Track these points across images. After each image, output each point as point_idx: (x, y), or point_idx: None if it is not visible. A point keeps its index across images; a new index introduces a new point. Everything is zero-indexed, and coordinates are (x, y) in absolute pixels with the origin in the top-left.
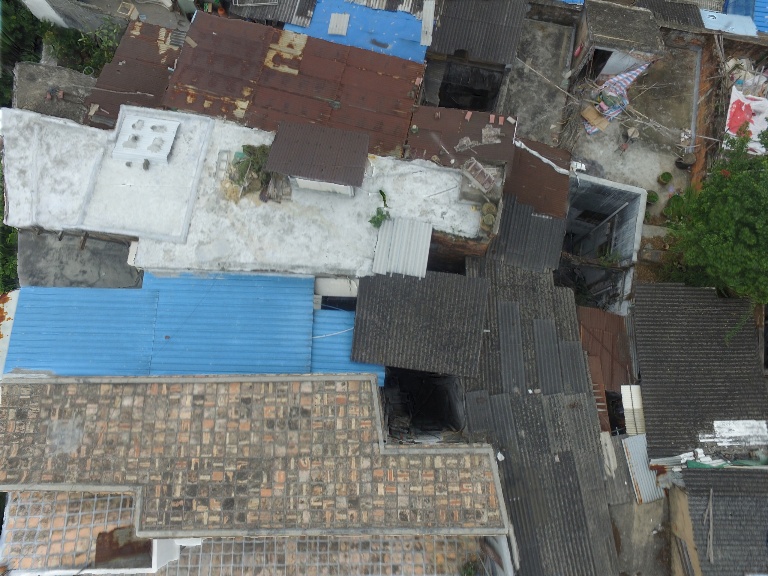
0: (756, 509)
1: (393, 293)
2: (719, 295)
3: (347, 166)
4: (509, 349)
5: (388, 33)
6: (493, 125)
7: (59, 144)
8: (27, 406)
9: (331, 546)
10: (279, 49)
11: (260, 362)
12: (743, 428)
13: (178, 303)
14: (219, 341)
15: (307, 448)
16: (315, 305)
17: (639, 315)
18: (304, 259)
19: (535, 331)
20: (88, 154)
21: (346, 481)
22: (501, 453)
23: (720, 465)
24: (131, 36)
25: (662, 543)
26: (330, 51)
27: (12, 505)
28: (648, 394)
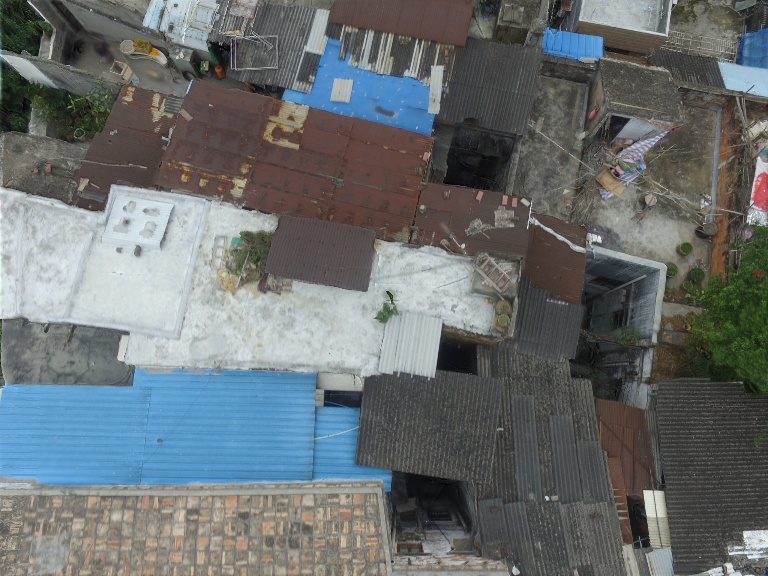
0: None
1: (400, 393)
2: (747, 390)
3: (352, 267)
4: (524, 449)
5: (394, 100)
6: (506, 207)
7: (46, 227)
8: (9, 520)
9: None
10: (279, 122)
11: (259, 467)
12: None
13: (171, 402)
14: (215, 444)
15: (309, 569)
16: (317, 402)
17: (662, 414)
18: (306, 357)
19: (551, 429)
20: (76, 238)
21: None
22: (516, 567)
23: None
24: (123, 103)
25: None
26: (333, 123)
27: None
28: (673, 502)
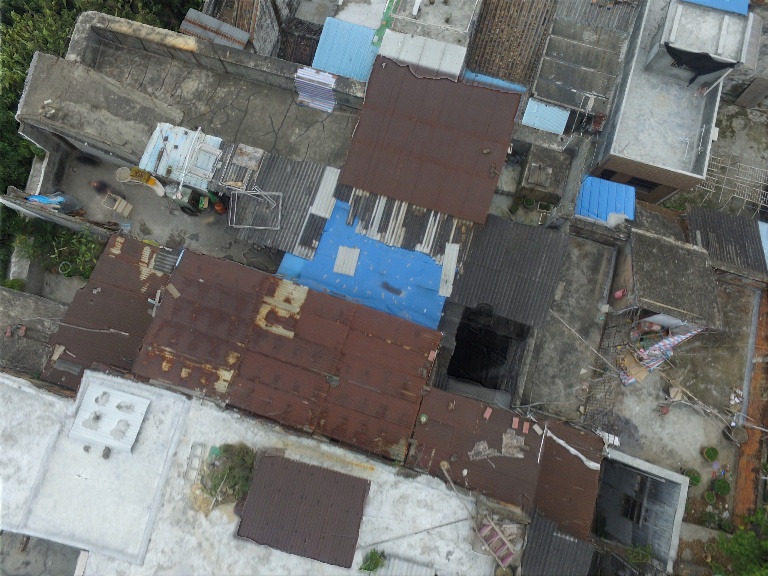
0: None
1: None
2: None
3: (336, 535)
4: None
5: (402, 277)
6: (516, 431)
7: (10, 413)
8: None
9: None
10: (274, 304)
11: None
12: None
13: None
14: None
15: None
16: None
17: None
18: None
19: None
20: (42, 430)
21: None
22: None
23: None
24: (110, 255)
25: None
26: (333, 309)
27: None
28: None
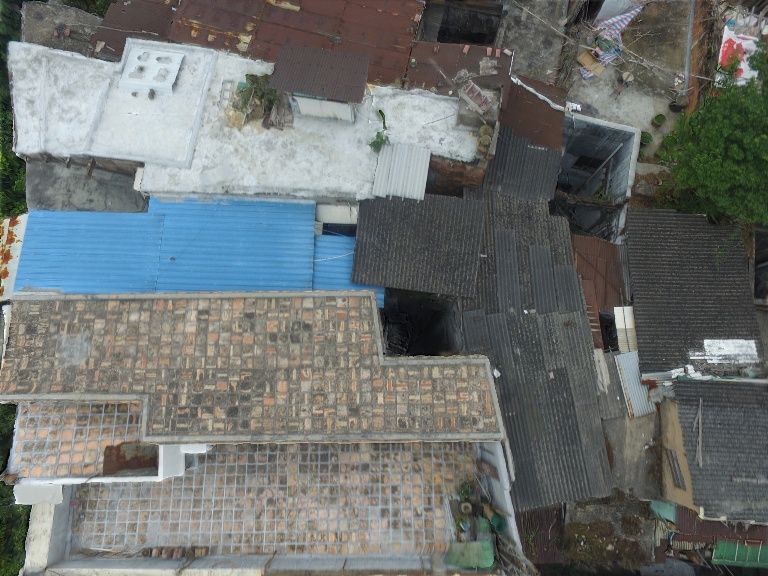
0: (744, 419)
1: (392, 216)
2: (710, 222)
3: (348, 85)
4: (505, 273)
5: None
6: (490, 57)
7: (66, 76)
8: (36, 322)
9: (332, 468)
10: None
11: (263, 283)
12: (732, 347)
13: (183, 226)
14: (223, 263)
15: (309, 360)
16: (316, 230)
17: (632, 239)
18: (306, 183)
19: (531, 256)
20: (95, 85)
21: (347, 391)
22: (497, 370)
23: (710, 379)
24: None
25: (653, 458)
26: None
27: (22, 417)
28: (640, 314)
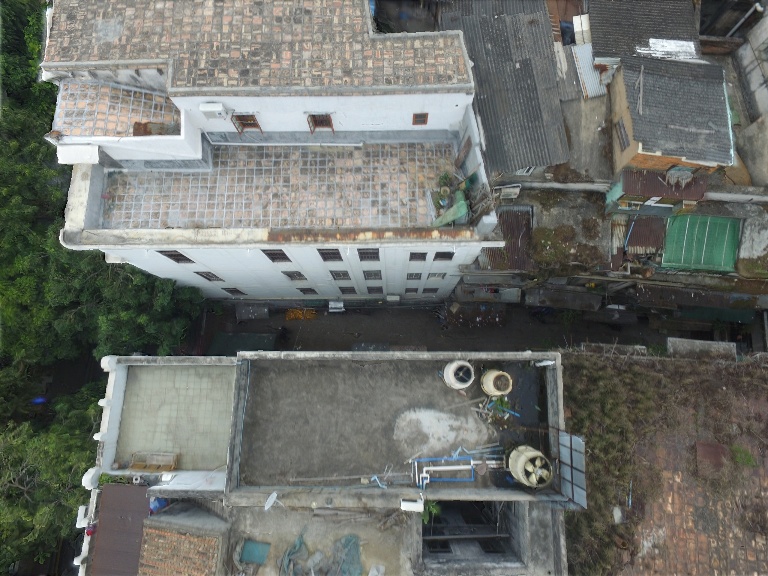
0: (680, 87)
1: None
2: None
3: None
4: None
5: None
6: None
7: None
8: (76, 11)
9: (329, 171)
10: None
11: None
12: (674, 46)
13: None
14: None
15: (309, 36)
16: None
17: None
18: None
19: None
20: None
21: (341, 59)
22: (471, 60)
23: None
24: None
25: (605, 140)
26: None
27: (64, 93)
28: (594, 16)
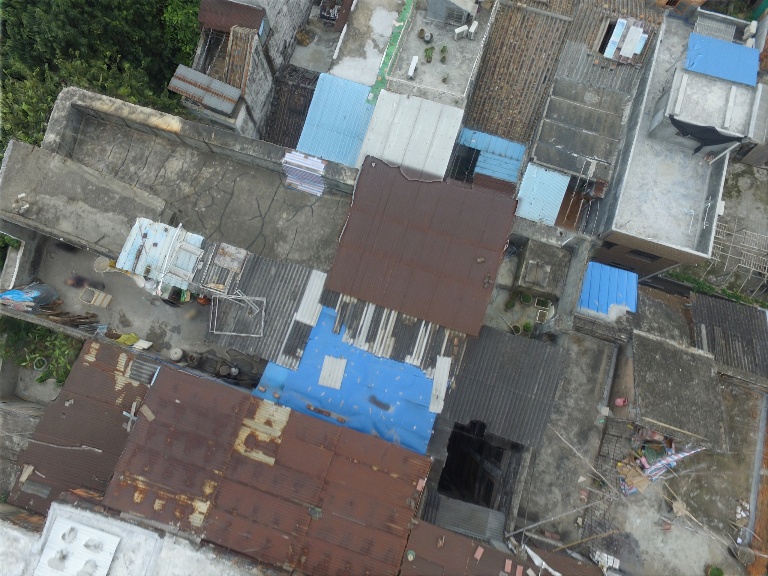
0: None
1: None
2: None
3: None
4: None
5: (391, 390)
6: (509, 575)
7: None
8: None
9: None
10: (254, 426)
11: None
12: None
13: None
14: None
15: None
16: None
17: None
18: None
19: None
20: (5, 568)
21: None
22: None
23: None
24: (84, 363)
25: None
26: (316, 432)
27: None
28: None
